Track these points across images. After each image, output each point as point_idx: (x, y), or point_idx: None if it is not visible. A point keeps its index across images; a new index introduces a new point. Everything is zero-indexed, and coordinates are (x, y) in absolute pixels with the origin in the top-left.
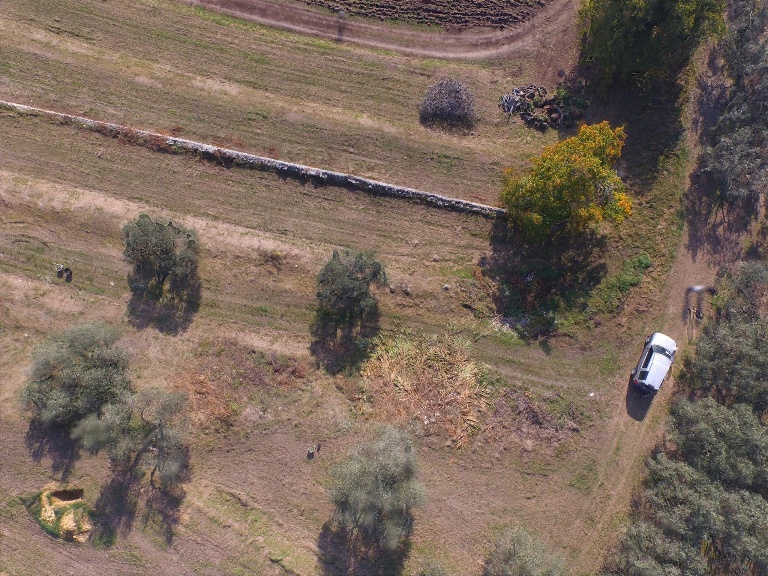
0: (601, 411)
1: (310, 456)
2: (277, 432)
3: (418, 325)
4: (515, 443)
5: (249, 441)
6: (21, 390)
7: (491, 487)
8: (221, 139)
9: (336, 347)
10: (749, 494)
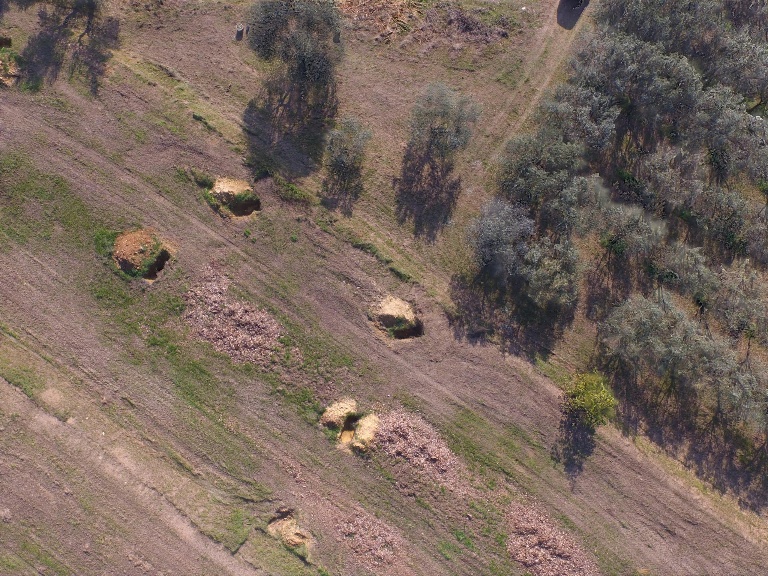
0: (531, 21)
1: (239, 38)
2: (207, 13)
3: None
4: (444, 44)
5: (179, 20)
6: None
7: (417, 78)
8: None
9: None
10: (666, 52)
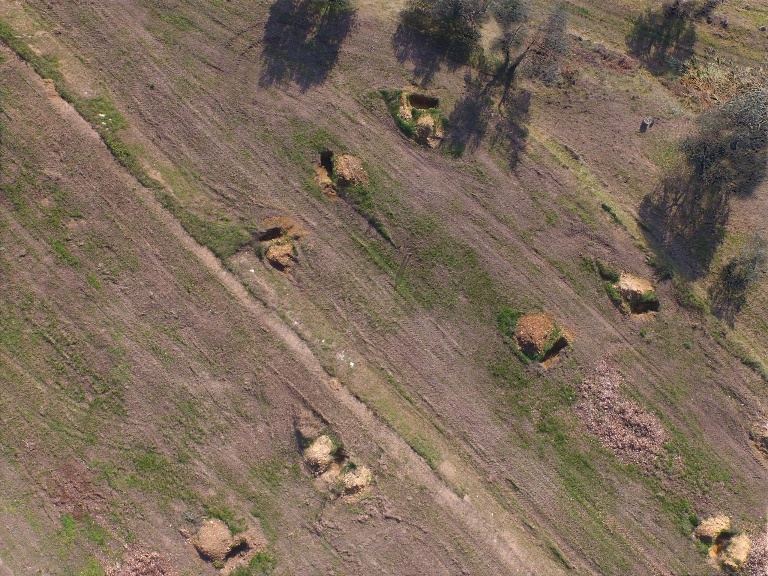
0: None
1: (642, 130)
2: (615, 100)
3: (732, 56)
4: None
5: (587, 102)
6: (382, 3)
7: None
8: None
9: (650, 60)
10: None
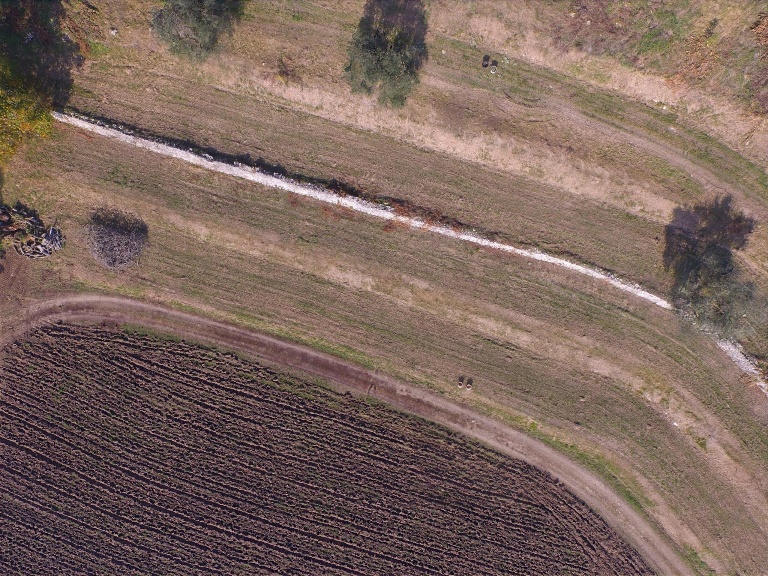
0: None
1: None
2: None
3: None
4: None
5: None
6: None
7: None
8: (344, 216)
9: None
10: None
